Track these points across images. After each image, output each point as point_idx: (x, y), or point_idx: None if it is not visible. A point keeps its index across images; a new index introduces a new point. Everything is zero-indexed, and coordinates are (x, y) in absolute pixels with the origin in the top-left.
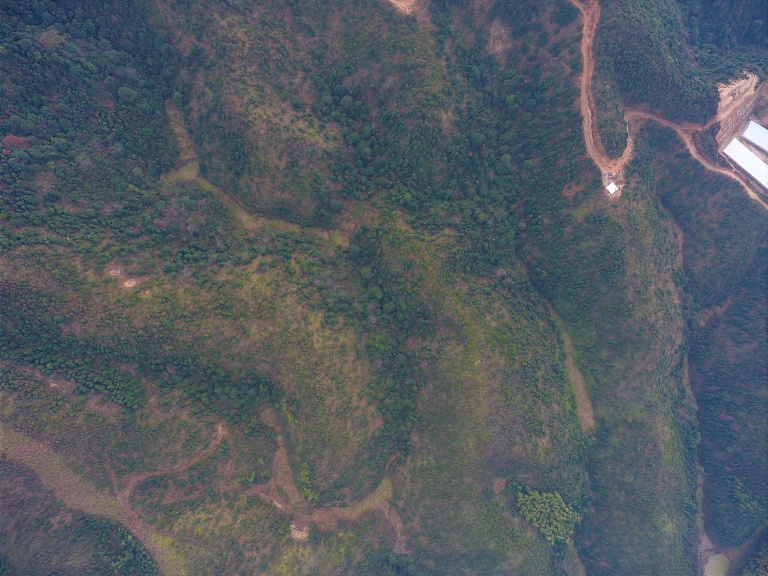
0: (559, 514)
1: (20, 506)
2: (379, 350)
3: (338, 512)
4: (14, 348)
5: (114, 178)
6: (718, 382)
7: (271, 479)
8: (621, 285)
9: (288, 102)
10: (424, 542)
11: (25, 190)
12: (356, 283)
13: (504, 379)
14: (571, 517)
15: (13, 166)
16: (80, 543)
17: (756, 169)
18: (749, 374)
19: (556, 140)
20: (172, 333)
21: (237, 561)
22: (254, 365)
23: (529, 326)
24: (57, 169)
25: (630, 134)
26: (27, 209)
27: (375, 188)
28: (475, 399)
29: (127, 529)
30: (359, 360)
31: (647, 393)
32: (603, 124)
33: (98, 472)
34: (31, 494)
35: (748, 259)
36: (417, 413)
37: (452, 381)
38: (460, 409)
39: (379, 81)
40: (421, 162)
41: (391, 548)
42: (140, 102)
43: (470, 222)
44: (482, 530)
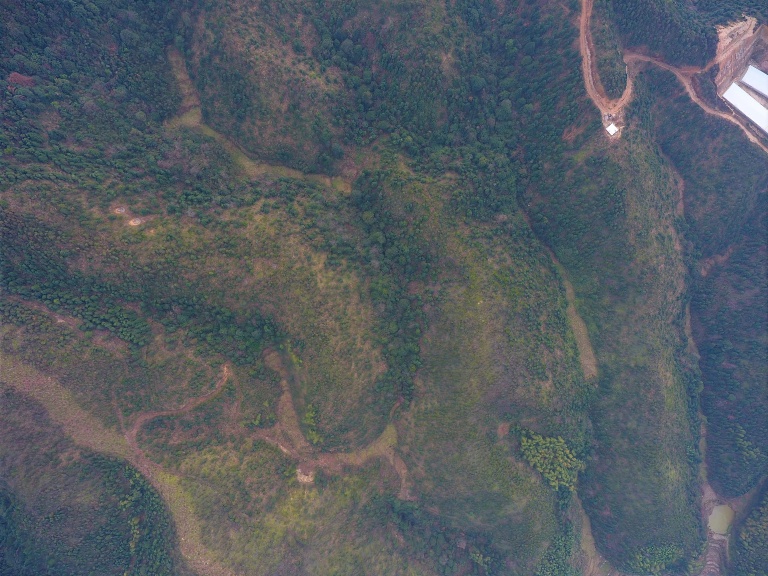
0: (563, 460)
1: (29, 440)
2: (382, 294)
3: (343, 458)
4: (21, 284)
5: (118, 121)
6: (720, 331)
7: (276, 424)
8: (622, 228)
9: (289, 45)
10: (429, 487)
11: (30, 128)
12: (358, 228)
13: (507, 320)
14: (575, 464)
15: (18, 103)
16: (88, 481)
17: (755, 113)
18: (751, 320)
19: (556, 82)
20: (177, 270)
21: (244, 501)
22: (258, 305)
23: (531, 271)
24: (61, 109)
25: (629, 76)
26: (32, 146)
27: (376, 133)
28: (478, 339)
29: (135, 468)
30: (362, 303)
31: (649, 337)
32: (602, 63)
33: (105, 409)
34: (40, 428)
35: (748, 206)
36: (420, 357)
37: (455, 321)
38: (463, 349)
39: (379, 23)
40: (422, 105)
41: (396, 494)
42: (142, 46)
43: (471, 166)
44: (486, 472)
